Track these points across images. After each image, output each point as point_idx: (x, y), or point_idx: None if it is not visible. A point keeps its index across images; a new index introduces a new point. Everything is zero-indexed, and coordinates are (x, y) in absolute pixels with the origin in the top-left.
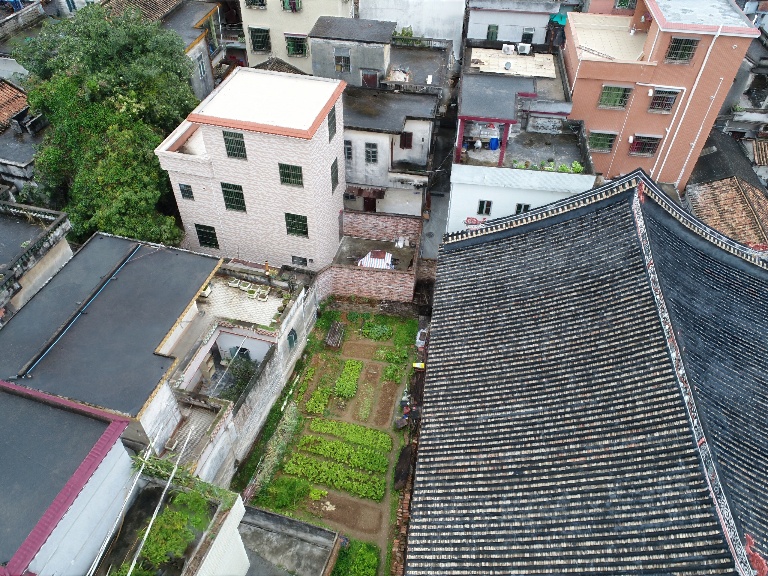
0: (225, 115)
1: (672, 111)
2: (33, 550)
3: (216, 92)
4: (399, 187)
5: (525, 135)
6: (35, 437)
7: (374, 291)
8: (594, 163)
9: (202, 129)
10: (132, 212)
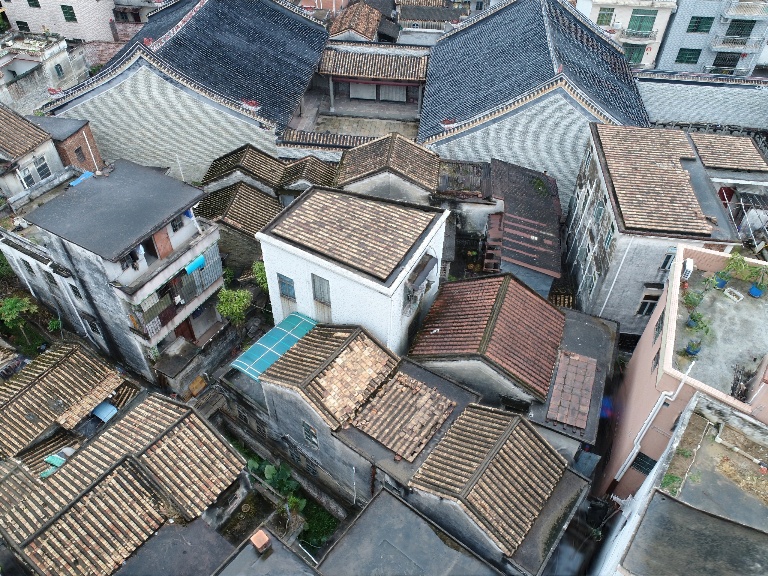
0: None
1: None
2: None
3: None
4: (148, 6)
5: None
6: None
7: None
8: None
9: None
10: None
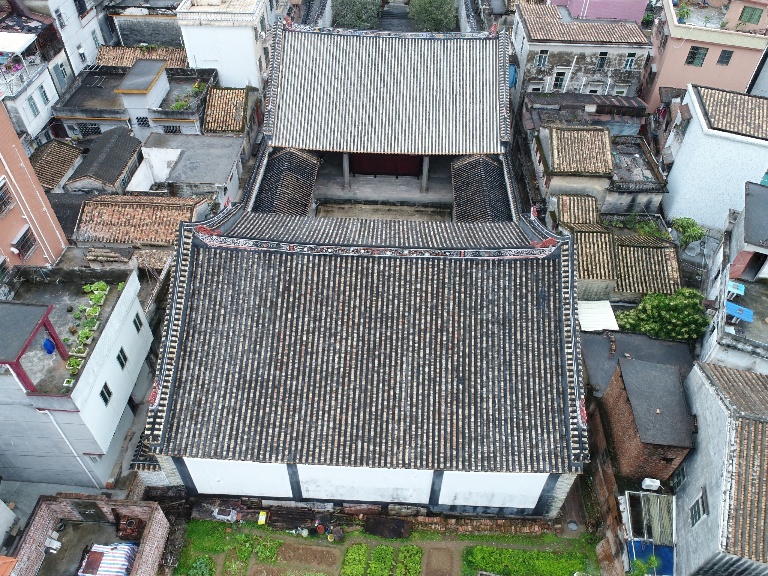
0: None
1: (13, 200)
2: None
3: None
4: None
5: None
6: None
7: (151, 571)
8: None
9: None
10: None
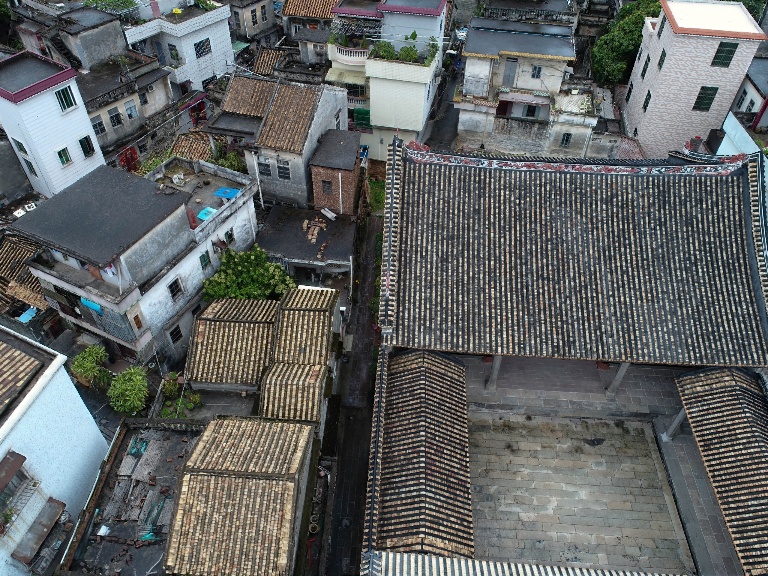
0: (675, 7)
1: None
2: (388, 8)
3: (699, 1)
4: None
5: None
6: (428, 2)
7: None
8: None
9: (661, 10)
10: (610, 45)
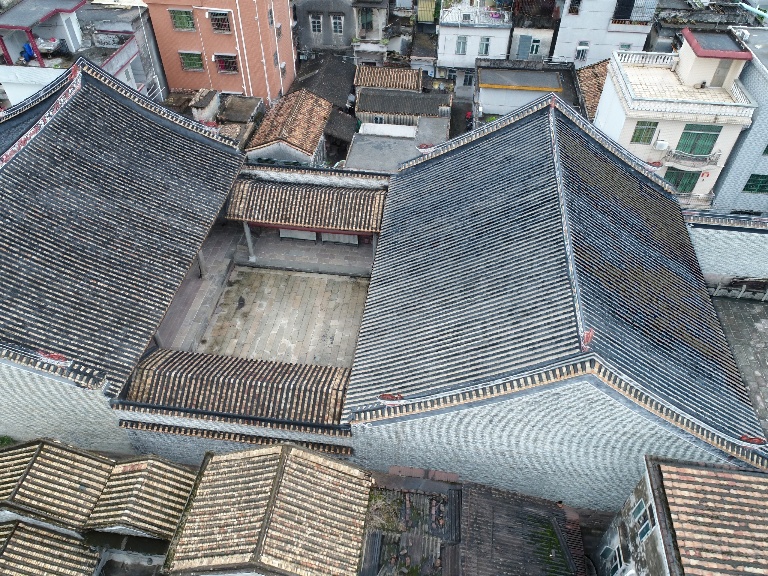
0: None
1: (233, 31)
2: None
3: None
4: None
5: (92, 49)
6: None
7: None
8: (197, 81)
9: None
10: None
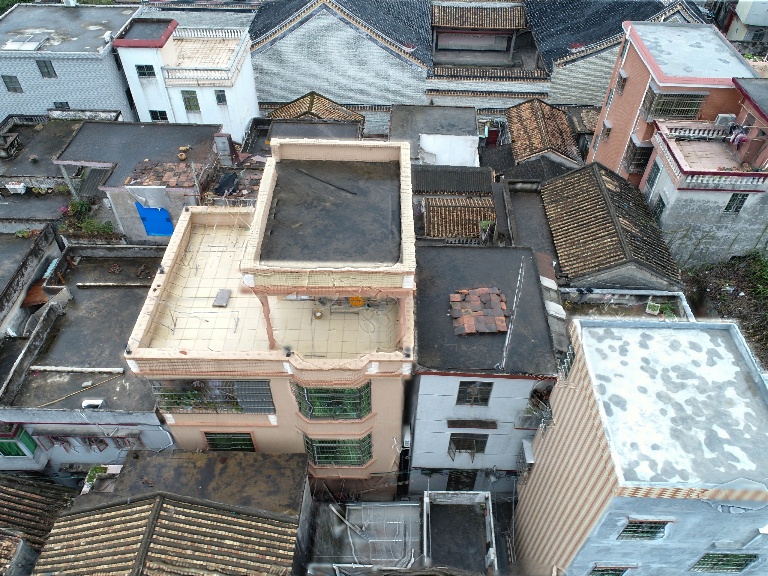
0: None
1: None
2: None
3: None
4: None
5: None
6: None
7: None
8: None
9: None
10: None
